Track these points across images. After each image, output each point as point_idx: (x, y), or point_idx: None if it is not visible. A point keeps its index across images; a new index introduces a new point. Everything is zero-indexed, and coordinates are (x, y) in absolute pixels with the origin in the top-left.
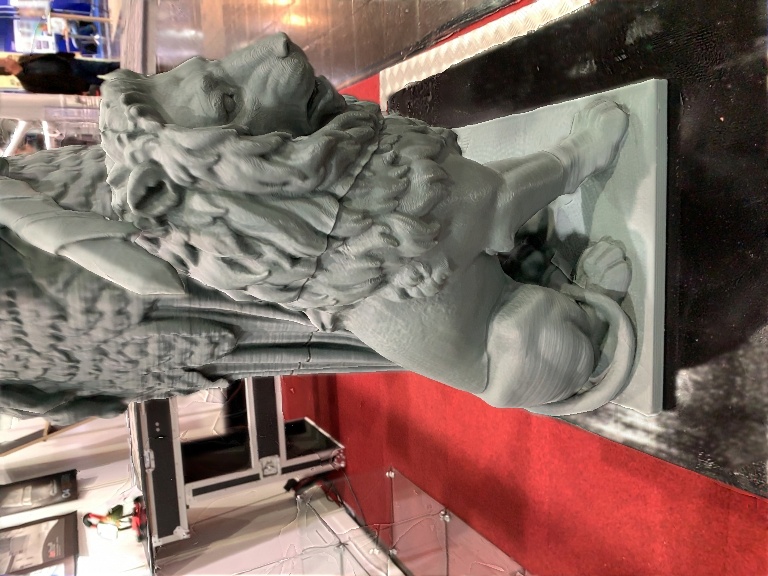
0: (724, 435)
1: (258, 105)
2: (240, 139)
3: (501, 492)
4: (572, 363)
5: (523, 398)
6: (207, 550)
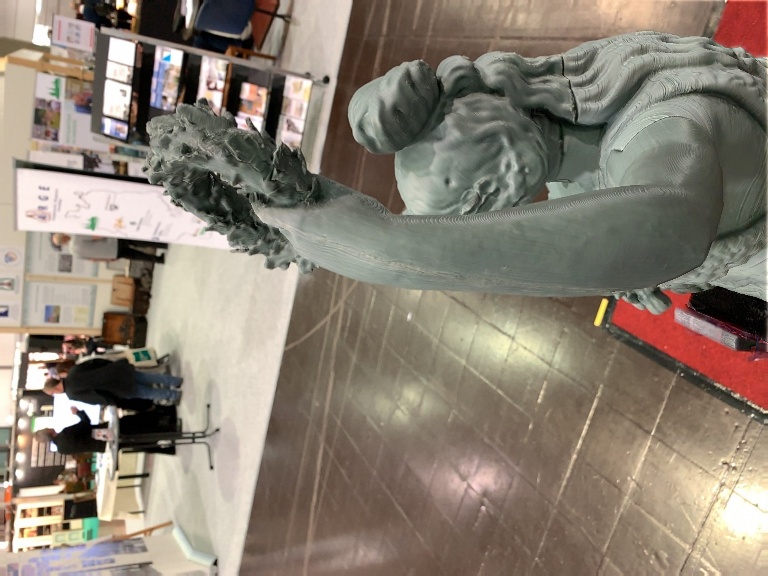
0: None
1: None
2: None
3: None
4: None
5: None
6: None
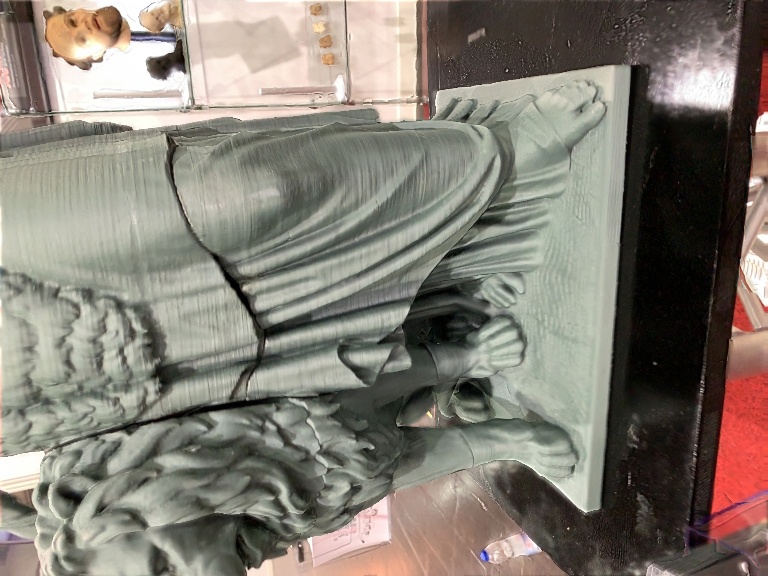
0: None
1: None
2: None
3: None
4: None
5: None
6: None
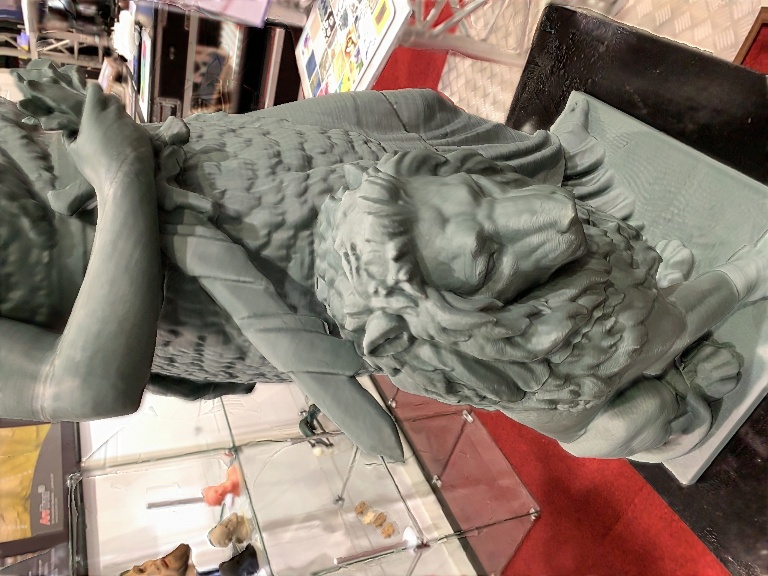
0: (738, 532)
1: (516, 269)
2: (496, 325)
3: None
4: None
5: None
6: None
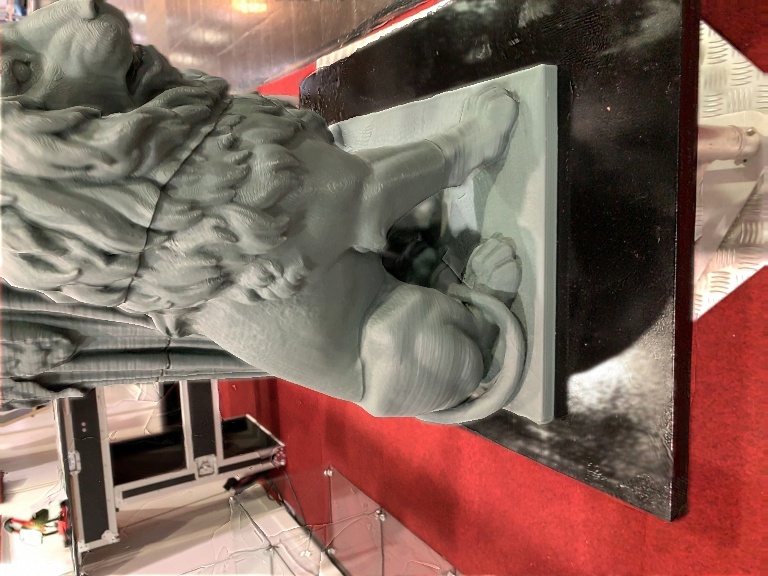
0: (611, 445)
1: (60, 75)
2: (26, 113)
3: (433, 491)
4: (454, 369)
5: (403, 407)
6: (139, 554)
